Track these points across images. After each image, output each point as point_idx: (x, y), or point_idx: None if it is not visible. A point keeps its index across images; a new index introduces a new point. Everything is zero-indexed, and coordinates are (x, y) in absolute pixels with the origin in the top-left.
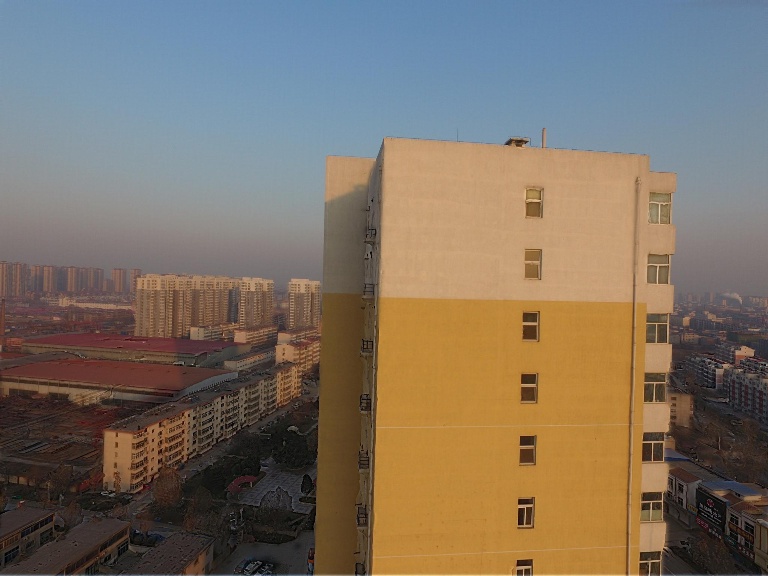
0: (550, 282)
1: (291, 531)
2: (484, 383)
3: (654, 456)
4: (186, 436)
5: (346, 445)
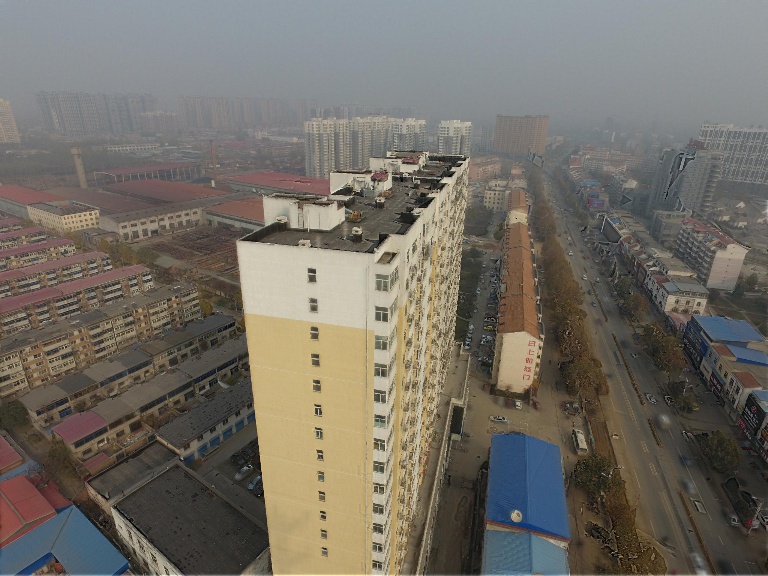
0: (322, 314)
1: None
2: (294, 355)
3: (381, 400)
4: None
5: None
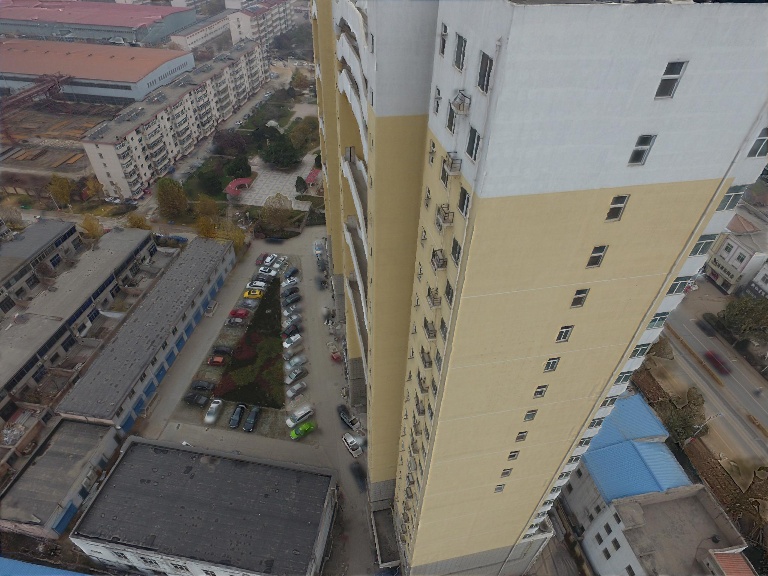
0: (652, 166)
1: (296, 228)
2: (559, 258)
3: (677, 290)
4: (166, 139)
5: (398, 252)
